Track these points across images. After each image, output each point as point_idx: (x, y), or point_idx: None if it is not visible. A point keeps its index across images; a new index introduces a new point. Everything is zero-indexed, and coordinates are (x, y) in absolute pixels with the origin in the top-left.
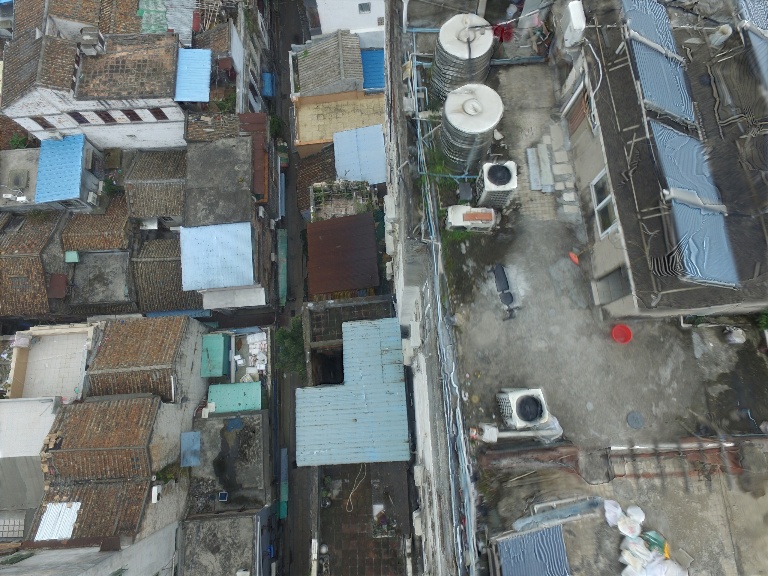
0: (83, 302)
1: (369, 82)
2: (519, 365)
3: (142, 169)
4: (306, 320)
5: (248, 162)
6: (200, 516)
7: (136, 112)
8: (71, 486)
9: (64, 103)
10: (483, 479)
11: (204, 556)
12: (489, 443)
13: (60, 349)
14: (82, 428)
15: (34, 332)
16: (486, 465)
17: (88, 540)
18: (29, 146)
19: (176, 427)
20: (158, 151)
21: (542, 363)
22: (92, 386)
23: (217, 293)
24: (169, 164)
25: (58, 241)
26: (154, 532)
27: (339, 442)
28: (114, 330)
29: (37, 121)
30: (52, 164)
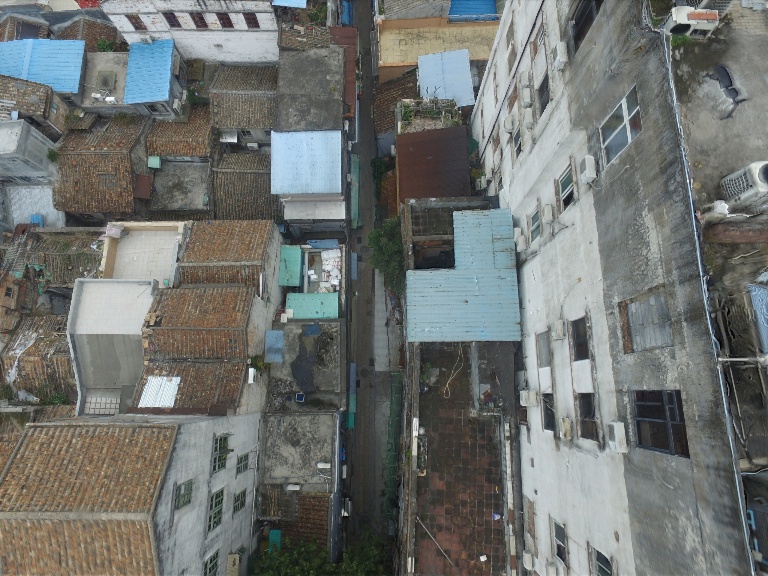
0: (162, 208)
1: (453, 10)
2: (738, 160)
3: (226, 80)
4: (408, 215)
5: (340, 72)
6: (281, 411)
7: (230, 17)
8: (170, 363)
9: (163, 1)
10: (709, 254)
11: (285, 448)
12: (720, 217)
13: (148, 244)
14: (180, 310)
15: (125, 224)
16: (723, 231)
17: (191, 410)
18: (115, 51)
19: (262, 323)
20: (240, 66)
21: (761, 158)
22: (182, 278)
23: (298, 204)
24: (252, 78)
25: (143, 144)
26: (247, 413)
27: (450, 321)
28: (201, 229)
29: (131, 21)
30: (141, 67)
